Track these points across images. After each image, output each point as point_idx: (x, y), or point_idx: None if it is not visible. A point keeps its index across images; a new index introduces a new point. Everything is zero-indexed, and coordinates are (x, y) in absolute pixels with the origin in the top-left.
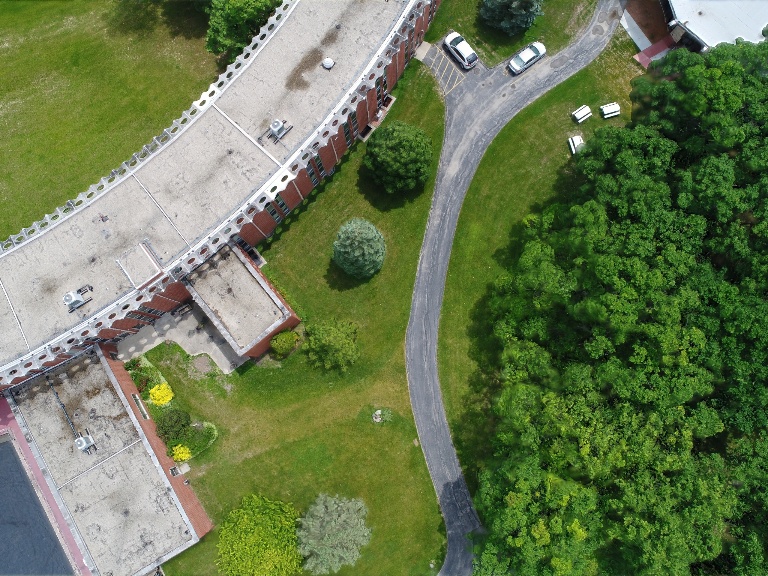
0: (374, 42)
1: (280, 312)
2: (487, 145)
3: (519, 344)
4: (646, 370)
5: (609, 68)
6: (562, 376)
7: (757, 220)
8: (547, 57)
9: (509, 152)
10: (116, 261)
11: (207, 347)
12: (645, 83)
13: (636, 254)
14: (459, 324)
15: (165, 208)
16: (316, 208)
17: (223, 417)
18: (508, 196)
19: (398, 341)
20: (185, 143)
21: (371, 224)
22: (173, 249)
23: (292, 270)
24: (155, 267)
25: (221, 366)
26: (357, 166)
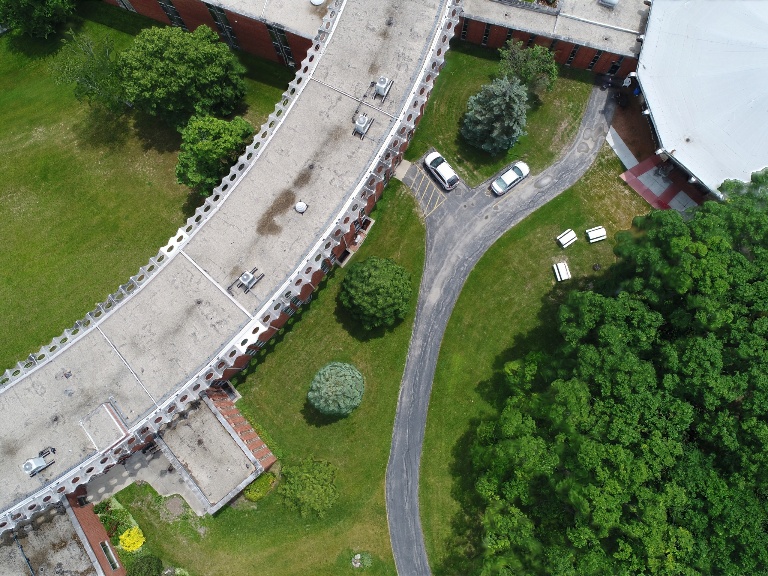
0: (349, 183)
1: (253, 466)
2: (469, 271)
3: (501, 507)
4: (631, 568)
5: (595, 188)
6: (544, 564)
7: (746, 411)
8: (531, 177)
9: (492, 278)
10: (79, 421)
11: (180, 487)
12: (629, 243)
13: (620, 442)
14: (441, 462)
15: (131, 363)
16: (292, 338)
17: (196, 562)
18: (491, 325)
19: (378, 480)
20: (152, 292)
21: (347, 371)
22: (139, 407)
23: (268, 405)
24: (120, 430)
25: (194, 508)
26: (335, 293)
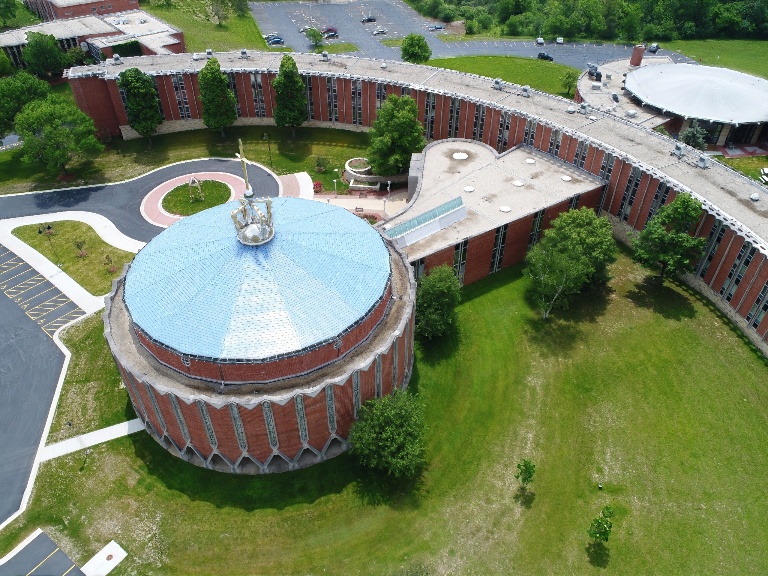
0: None
1: None
2: None
3: None
4: None
5: None
6: None
7: None
8: None
9: None
10: None
11: None
12: None
13: None
14: None
15: None
16: None
17: None
18: None
19: None
20: None
21: None
22: None
23: None
24: None
25: None
26: None
